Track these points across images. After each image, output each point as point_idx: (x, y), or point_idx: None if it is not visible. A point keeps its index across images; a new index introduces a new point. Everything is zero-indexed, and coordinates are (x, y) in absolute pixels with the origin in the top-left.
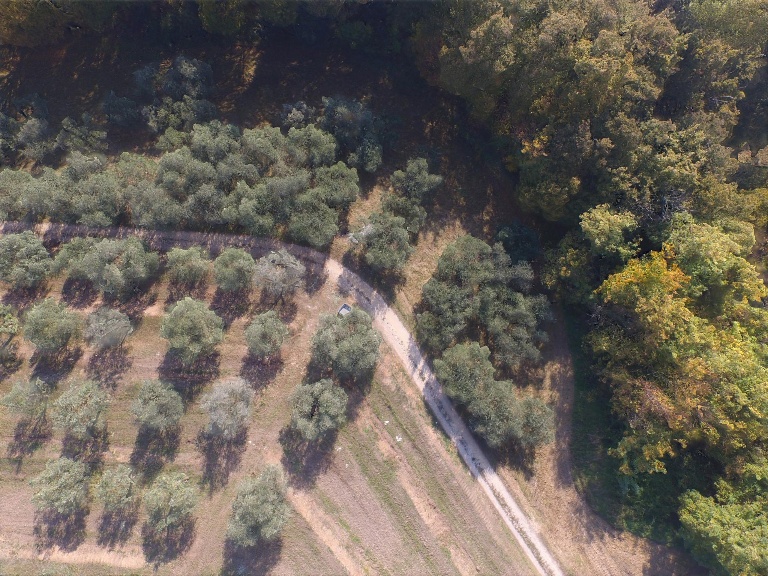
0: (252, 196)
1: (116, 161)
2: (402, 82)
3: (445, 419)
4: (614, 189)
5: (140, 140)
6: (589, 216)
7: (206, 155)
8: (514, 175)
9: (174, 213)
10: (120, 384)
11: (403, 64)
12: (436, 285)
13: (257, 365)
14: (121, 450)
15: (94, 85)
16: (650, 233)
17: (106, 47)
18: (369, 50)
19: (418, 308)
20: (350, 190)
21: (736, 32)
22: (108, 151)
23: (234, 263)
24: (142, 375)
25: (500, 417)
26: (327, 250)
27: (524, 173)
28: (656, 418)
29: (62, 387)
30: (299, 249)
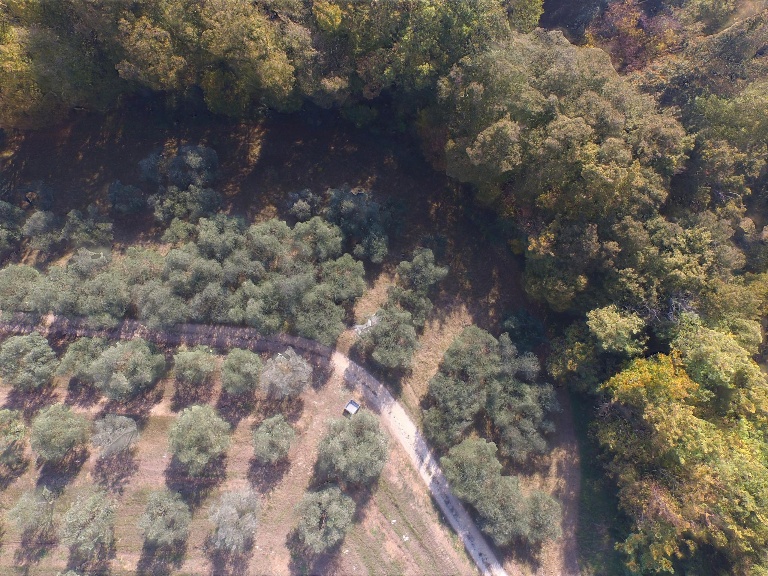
0: (259, 296)
1: (121, 249)
2: (407, 162)
3: (452, 514)
4: (621, 288)
5: (145, 226)
6: (596, 314)
7: (212, 249)
8: (519, 256)
9: (181, 314)
10: (127, 489)
11: (408, 144)
12: (443, 381)
13: (264, 467)
14: (128, 557)
15: (99, 166)
16: (657, 329)
17: (111, 126)
18: (374, 130)
19: (424, 400)
20: (356, 286)
21: (742, 128)
22: (113, 239)
23: (241, 369)
24: (149, 478)
25: (507, 517)
26: (333, 343)
27: (530, 263)
28: (663, 517)
29: (69, 492)
30: (305, 342)
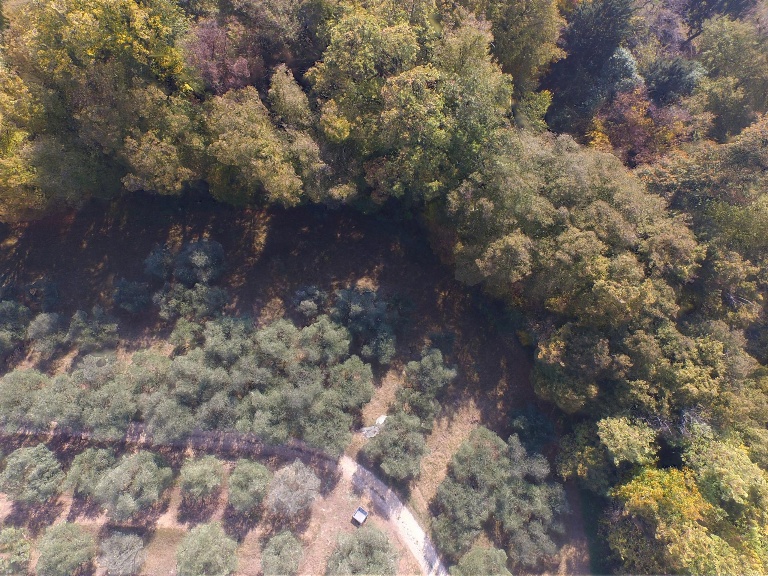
0: (266, 407)
1: (127, 346)
2: (414, 249)
3: None
4: (632, 398)
5: (150, 321)
6: (607, 424)
7: None
8: (528, 346)
9: (187, 427)
10: None
11: (415, 231)
12: (452, 487)
13: None
14: None
15: (103, 255)
16: None
17: (115, 212)
18: (381, 218)
19: (433, 503)
20: (364, 392)
21: (754, 233)
22: None
23: (249, 488)
24: None
25: None
26: None
27: (539, 362)
28: None
29: None
30: None
